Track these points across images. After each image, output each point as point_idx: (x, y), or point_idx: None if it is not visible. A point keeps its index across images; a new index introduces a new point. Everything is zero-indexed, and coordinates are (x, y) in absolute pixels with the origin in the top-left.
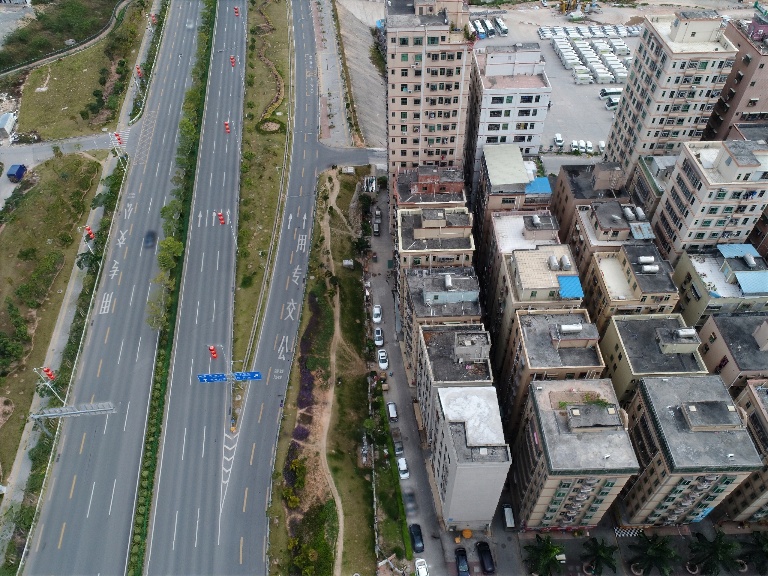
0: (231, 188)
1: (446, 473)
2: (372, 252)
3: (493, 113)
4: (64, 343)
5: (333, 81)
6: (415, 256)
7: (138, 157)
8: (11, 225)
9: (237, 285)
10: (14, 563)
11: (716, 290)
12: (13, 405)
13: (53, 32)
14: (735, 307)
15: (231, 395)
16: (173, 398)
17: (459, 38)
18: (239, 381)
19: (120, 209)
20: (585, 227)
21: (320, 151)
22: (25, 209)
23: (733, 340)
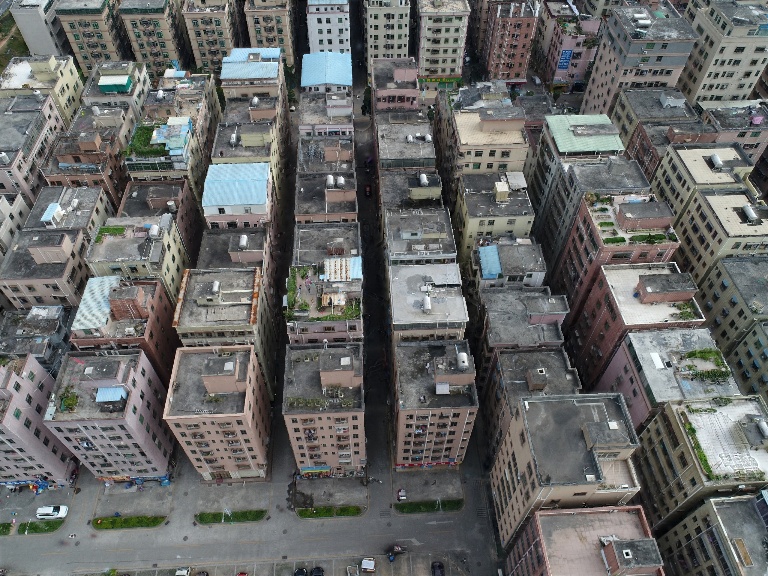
0: None
1: None
2: None
3: None
4: None
5: None
6: None
7: None
8: None
9: None
10: None
11: None
12: None
13: None
14: None
15: None
16: None
17: None
18: None
19: None
20: None
21: None
22: None
23: None
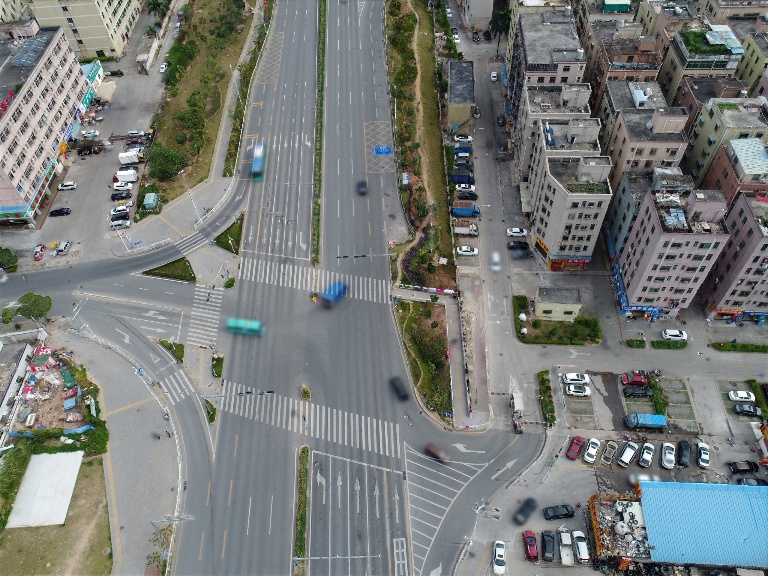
0: None
1: None
2: None
3: None
4: None
5: None
6: None
7: None
8: None
9: None
10: (266, 27)
11: None
12: None
13: None
14: None
15: None
16: None
17: None
18: None
19: None
20: None
21: None
22: None
23: None
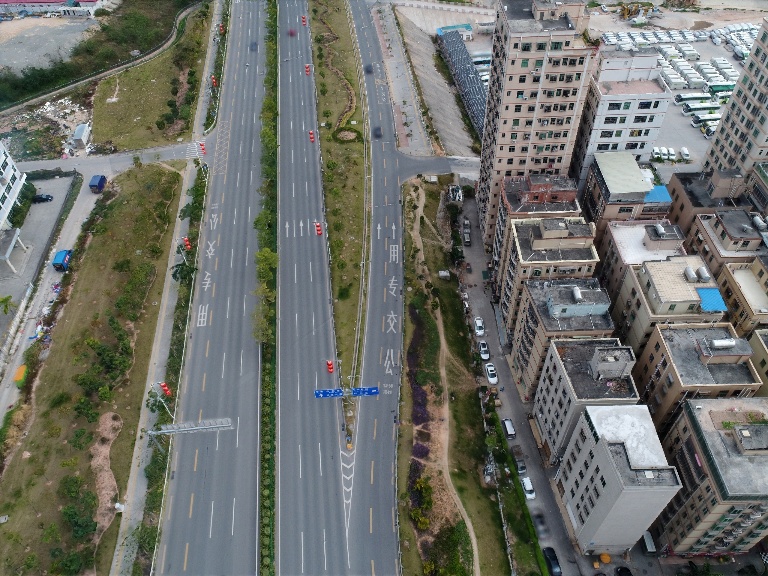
0: (315, 198)
1: (595, 496)
2: (465, 263)
3: (608, 120)
4: (165, 356)
5: (404, 89)
6: (536, 267)
7: (217, 167)
8: (99, 236)
9: (334, 297)
10: None
11: None
12: (121, 420)
13: (118, 43)
14: None
15: (343, 411)
16: (283, 413)
17: (579, 43)
18: (349, 396)
19: (205, 220)
20: (710, 237)
21: (400, 160)
22: (111, 220)
23: None
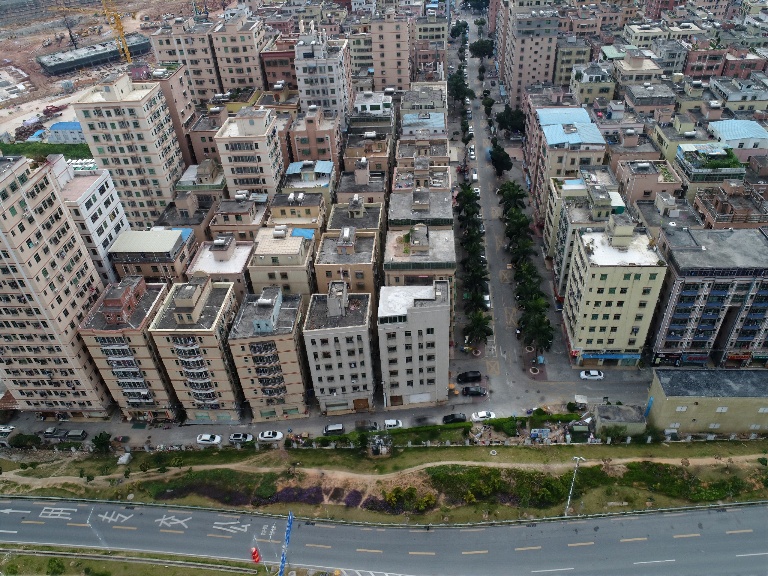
0: None
1: (432, 348)
2: (112, 441)
3: (93, 219)
4: None
5: None
6: (219, 325)
7: None
8: None
9: None
10: None
11: None
12: None
13: None
14: (332, 186)
15: None
16: None
17: None
18: (268, 575)
19: None
20: None
21: None
22: None
23: None
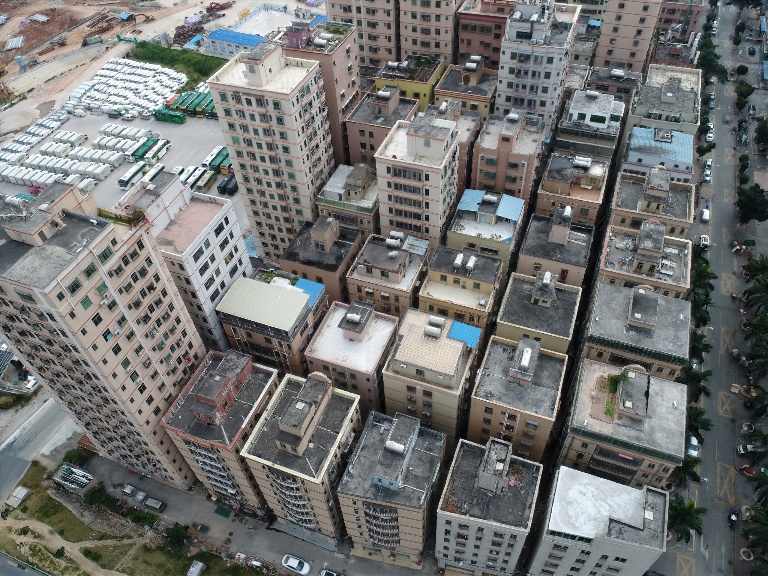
0: None
1: (614, 573)
2: (189, 528)
3: (201, 270)
4: None
5: None
6: (329, 468)
7: None
8: None
9: None
10: None
11: (499, 236)
12: None
13: None
14: (515, 236)
15: None
16: None
17: None
18: None
19: None
20: None
21: None
22: None
23: (550, 255)
